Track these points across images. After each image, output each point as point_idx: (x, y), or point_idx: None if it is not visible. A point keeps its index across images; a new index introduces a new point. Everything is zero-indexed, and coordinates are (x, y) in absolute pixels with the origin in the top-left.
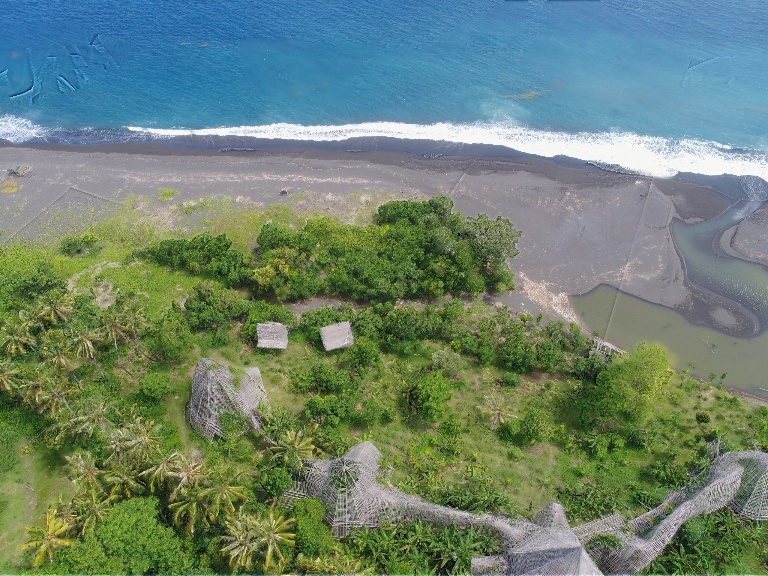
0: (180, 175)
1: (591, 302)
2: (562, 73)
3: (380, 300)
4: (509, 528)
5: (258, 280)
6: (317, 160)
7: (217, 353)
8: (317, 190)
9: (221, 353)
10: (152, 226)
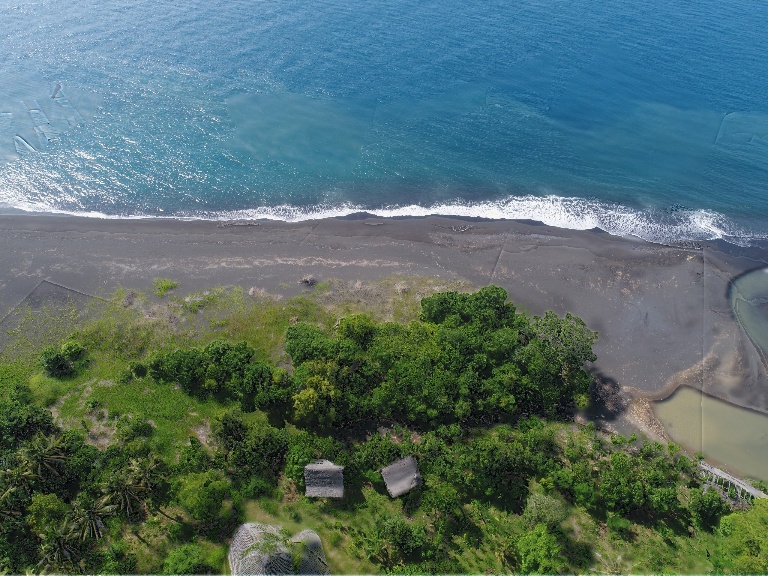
0: (176, 260)
1: (676, 409)
2: (589, 133)
3: (441, 420)
4: None
5: (300, 409)
6: (334, 237)
7: (253, 504)
8: (342, 277)
9: (258, 504)
10: (151, 330)
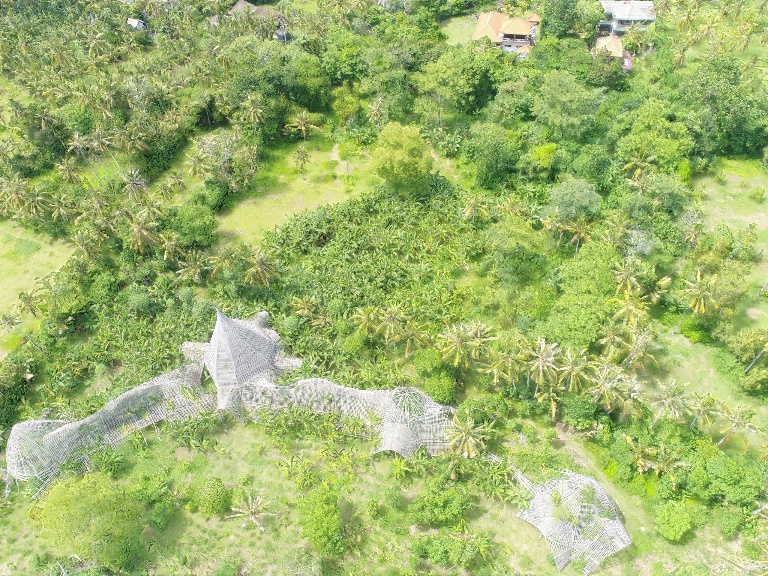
0: None
1: None
2: None
3: None
4: (267, 385)
5: None
6: None
7: None
8: None
9: None
10: None
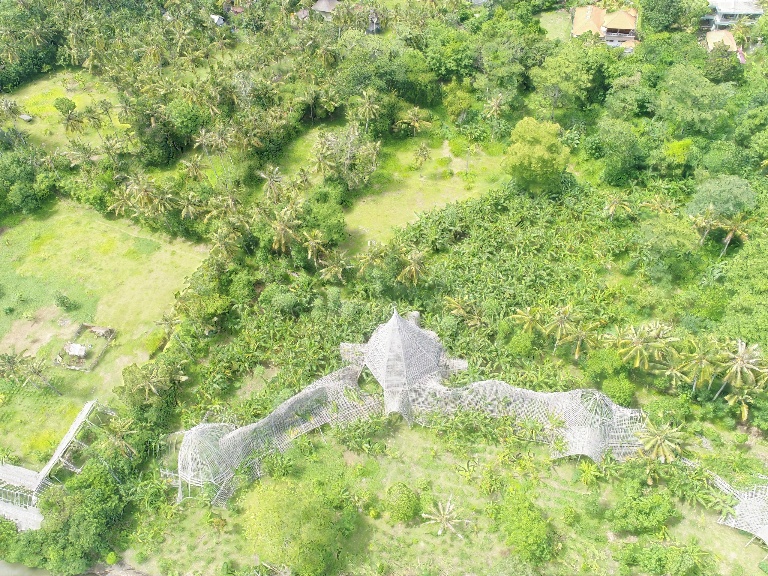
0: None
1: None
2: None
3: None
4: (438, 387)
5: None
6: None
7: None
8: None
9: None
10: None
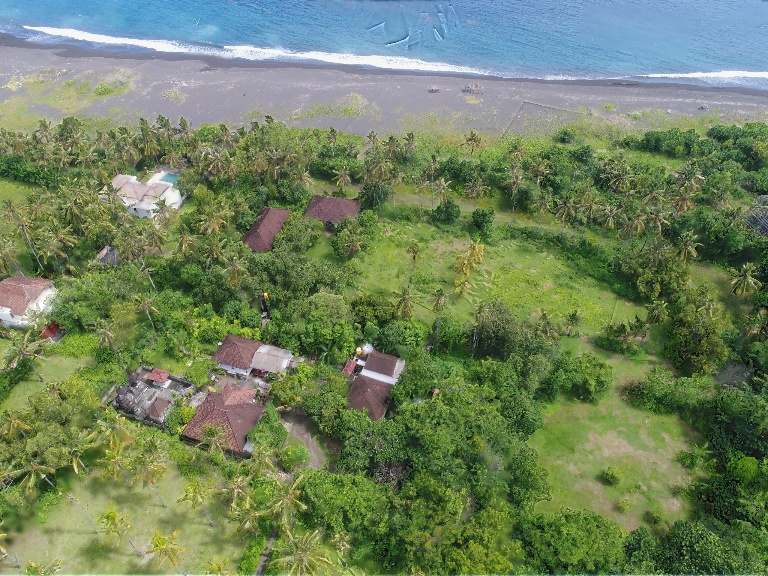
0: (602, 96)
1: None
2: None
3: None
4: None
5: (763, 152)
6: (698, 91)
7: (738, 203)
8: None
9: (741, 203)
10: (616, 126)
